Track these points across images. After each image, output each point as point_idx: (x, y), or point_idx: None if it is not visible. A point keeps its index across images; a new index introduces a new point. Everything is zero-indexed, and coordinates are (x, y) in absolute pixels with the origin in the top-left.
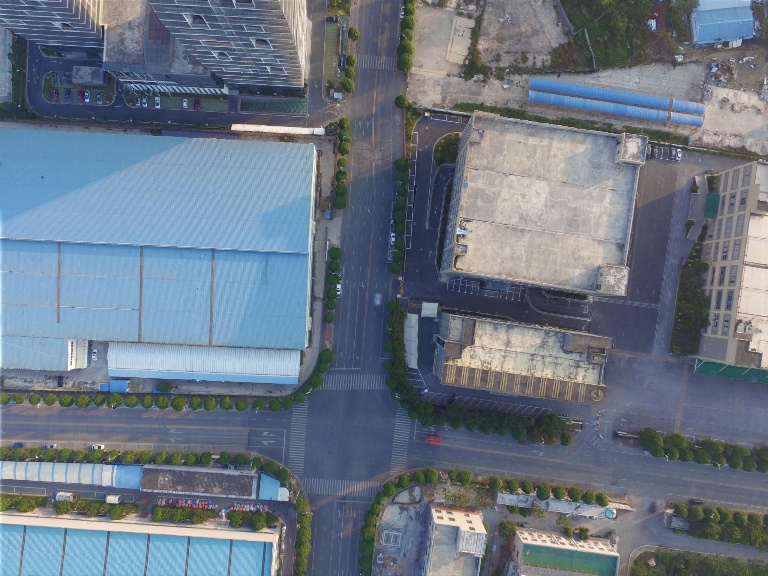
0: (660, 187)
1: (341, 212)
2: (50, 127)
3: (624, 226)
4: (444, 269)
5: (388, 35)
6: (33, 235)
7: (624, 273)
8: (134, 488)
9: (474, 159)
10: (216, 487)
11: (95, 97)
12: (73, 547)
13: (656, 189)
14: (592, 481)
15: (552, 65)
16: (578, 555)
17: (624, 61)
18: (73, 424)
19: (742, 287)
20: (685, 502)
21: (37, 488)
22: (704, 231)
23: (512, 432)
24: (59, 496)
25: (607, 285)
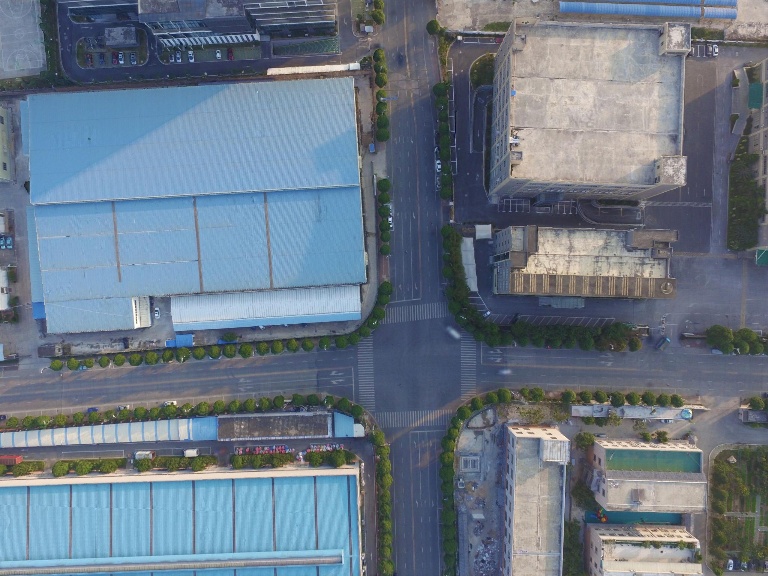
0: (700, 85)
1: (384, 145)
2: None
3: (675, 117)
4: (496, 186)
5: None
6: (87, 196)
7: (682, 162)
8: (211, 439)
9: (518, 67)
10: (292, 429)
11: (129, 58)
12: (160, 500)
13: (696, 87)
14: (663, 386)
15: None
16: (661, 455)
17: None
18: (143, 384)
19: None
20: (759, 396)
21: (115, 451)
22: (749, 124)
23: (579, 343)
24: (138, 455)
25: (666, 176)
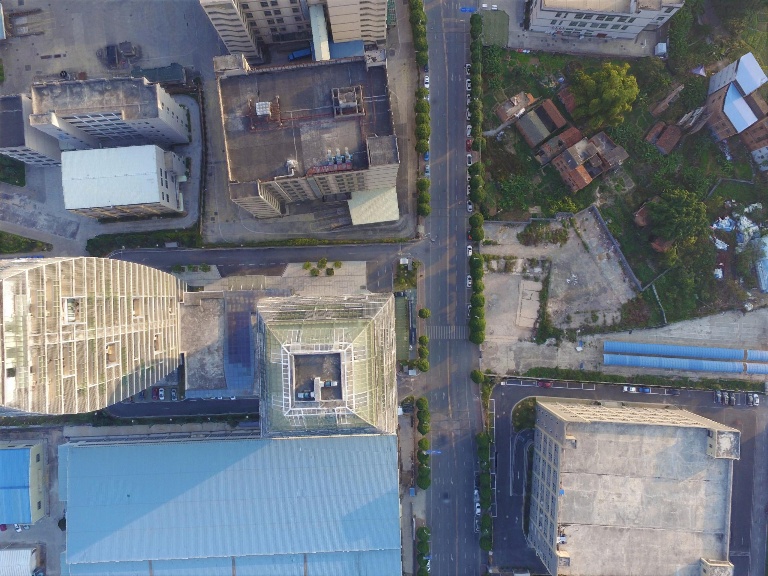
0: None
1: None
2: (126, 426)
3: (722, 516)
4: (537, 551)
5: (456, 304)
6: (124, 557)
7: (728, 572)
8: None
9: (566, 462)
10: None
11: (169, 393)
12: None
13: None
14: None
15: (623, 322)
16: None
17: (694, 312)
18: None
19: None
20: None
21: None
22: None
23: None
24: None
25: None
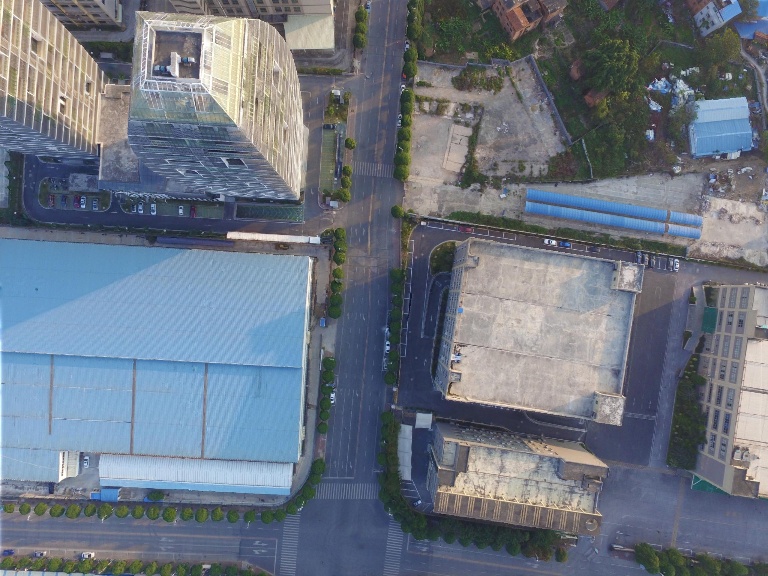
0: (657, 297)
1: (336, 319)
2: (46, 232)
3: (620, 352)
4: (439, 384)
5: (385, 142)
6: (26, 348)
7: (620, 403)
8: None
9: (469, 283)
10: None
11: (91, 203)
12: None
13: (653, 299)
14: None
15: (549, 174)
16: None
17: (622, 171)
18: (63, 531)
19: (739, 412)
20: None
21: None
22: (702, 343)
23: (506, 547)
24: None
25: (602, 415)
